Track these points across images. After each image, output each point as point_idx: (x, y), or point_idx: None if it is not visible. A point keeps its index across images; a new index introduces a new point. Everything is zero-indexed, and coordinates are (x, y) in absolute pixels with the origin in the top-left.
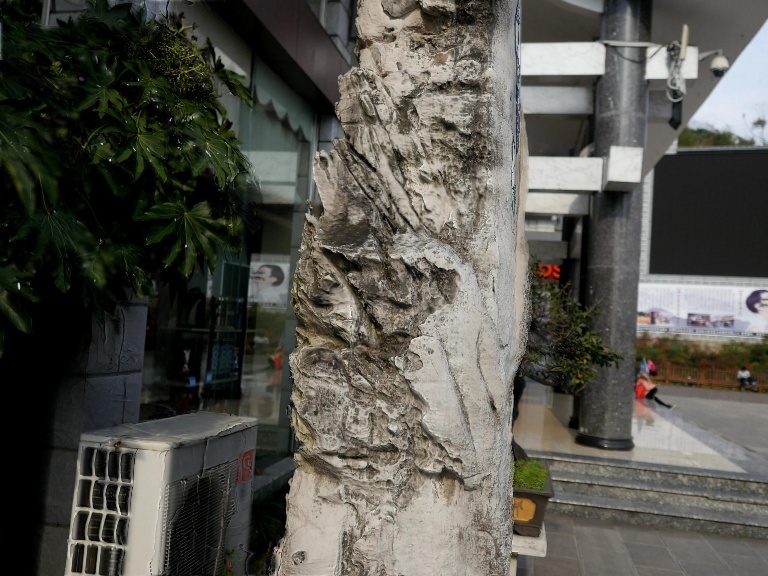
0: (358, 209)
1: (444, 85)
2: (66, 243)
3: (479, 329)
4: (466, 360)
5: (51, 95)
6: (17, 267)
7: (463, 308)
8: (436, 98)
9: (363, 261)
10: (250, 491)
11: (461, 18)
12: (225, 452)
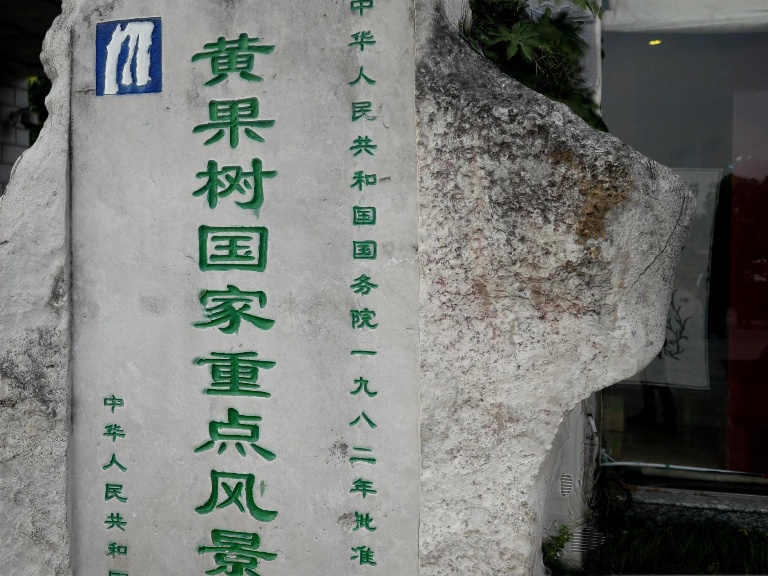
0: None
1: None
2: None
3: None
4: None
5: None
6: None
7: None
8: None
9: None
10: None
11: None
12: None
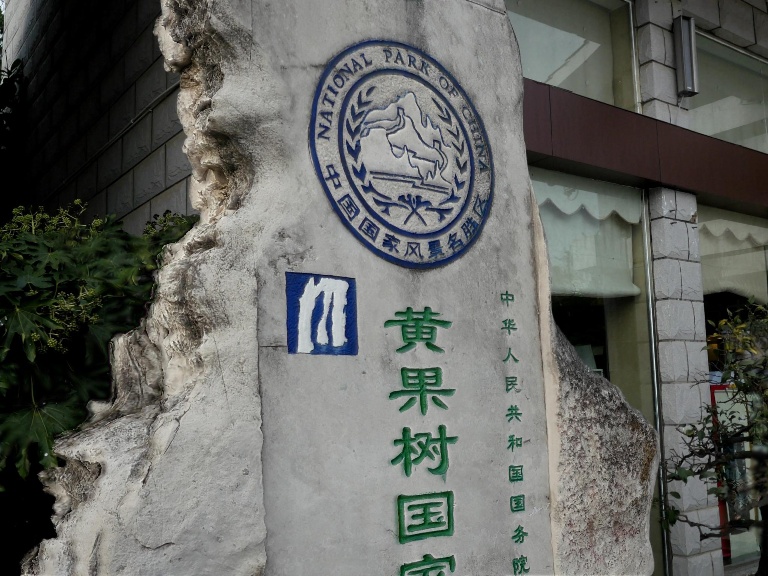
0: (122, 391)
1: (188, 247)
2: (50, 428)
3: (97, 531)
4: (81, 567)
5: (115, 295)
6: (0, 455)
7: (90, 506)
8: (162, 267)
9: (56, 455)
10: None
11: (227, 166)
12: None
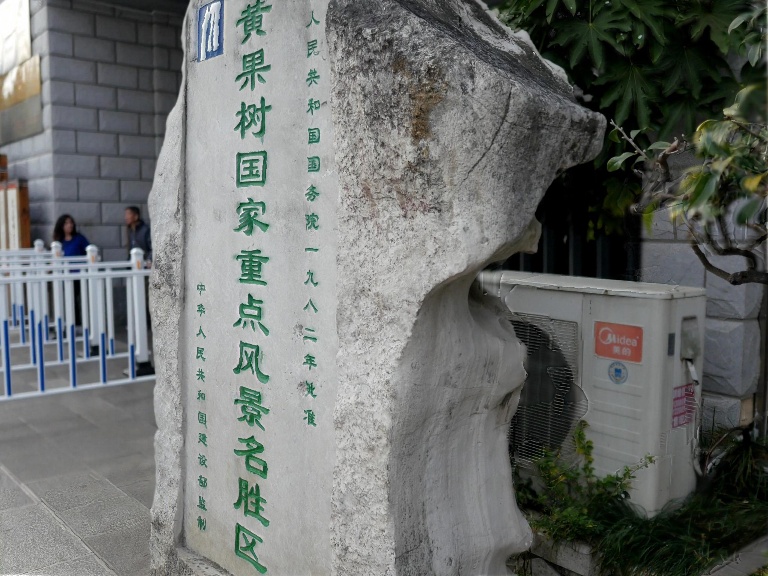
0: None
1: None
2: None
3: None
4: None
5: None
6: None
7: None
8: None
9: None
10: (607, 370)
11: None
12: (534, 303)
